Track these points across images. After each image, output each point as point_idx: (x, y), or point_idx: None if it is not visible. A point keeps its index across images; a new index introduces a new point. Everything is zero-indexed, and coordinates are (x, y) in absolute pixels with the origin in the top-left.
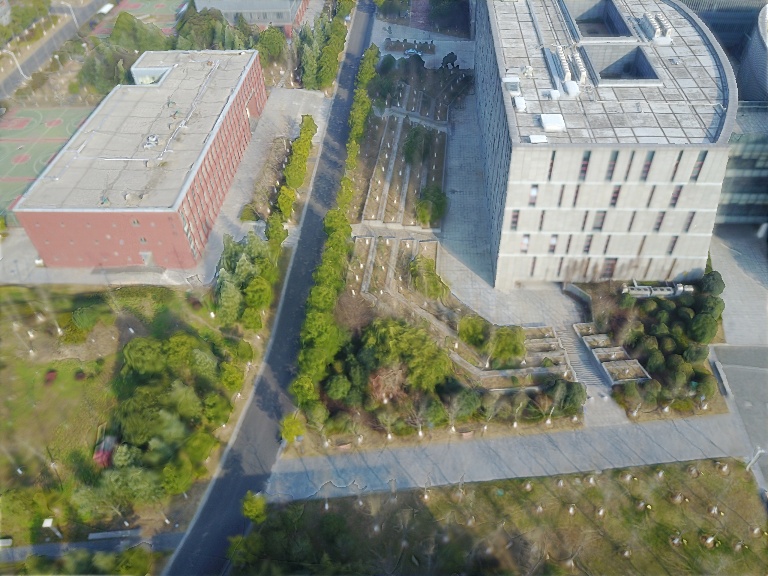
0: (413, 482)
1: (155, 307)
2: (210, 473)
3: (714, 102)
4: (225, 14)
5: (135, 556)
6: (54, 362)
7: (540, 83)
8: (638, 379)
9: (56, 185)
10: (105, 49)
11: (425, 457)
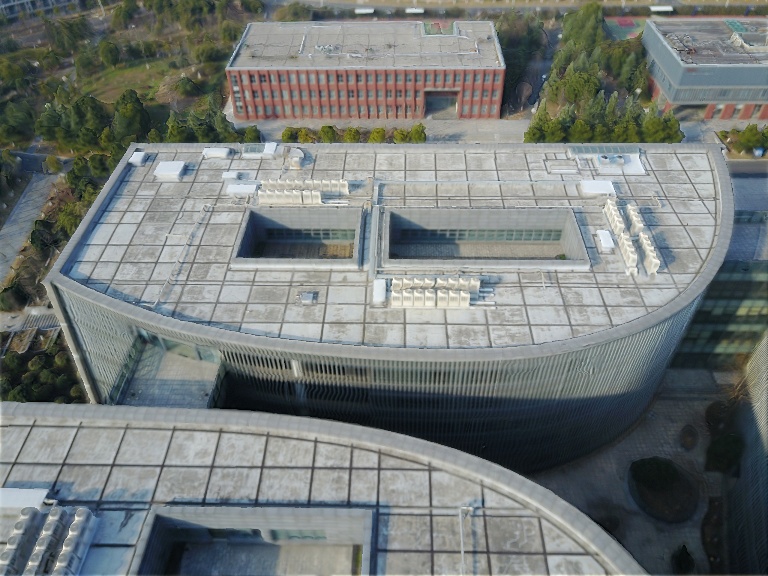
0: (6, 227)
1: (199, 111)
2: (63, 154)
3: (168, 306)
4: (649, 55)
5: (3, 125)
6: (158, 86)
7: (270, 173)
8: (6, 347)
9: (275, 29)
10: (519, 13)
11: (20, 232)
